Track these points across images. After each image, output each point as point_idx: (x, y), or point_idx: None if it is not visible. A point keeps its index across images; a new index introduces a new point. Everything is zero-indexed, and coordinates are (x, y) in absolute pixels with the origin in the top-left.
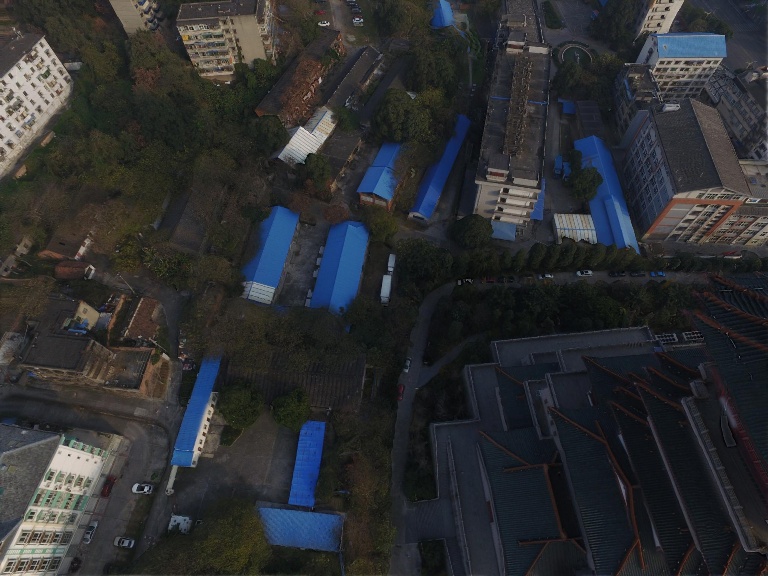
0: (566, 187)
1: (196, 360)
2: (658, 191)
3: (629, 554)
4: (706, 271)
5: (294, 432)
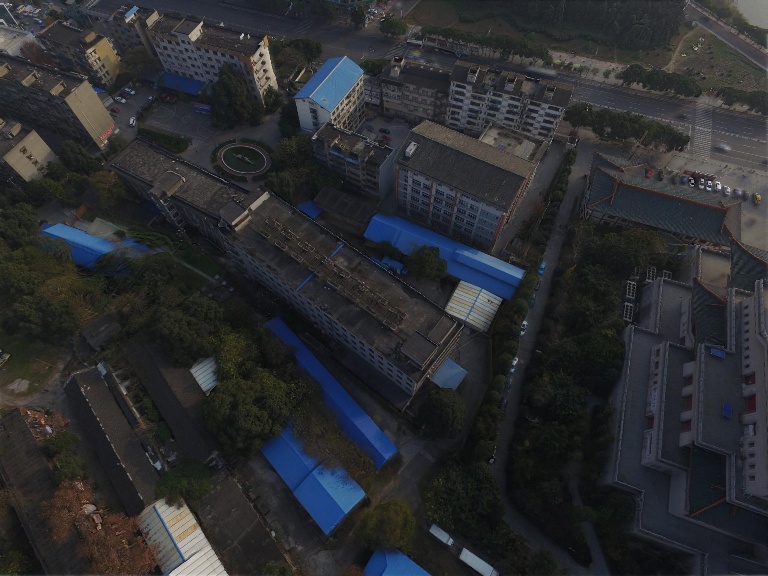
0: (409, 277)
1: None
2: (477, 216)
3: None
4: None
5: None
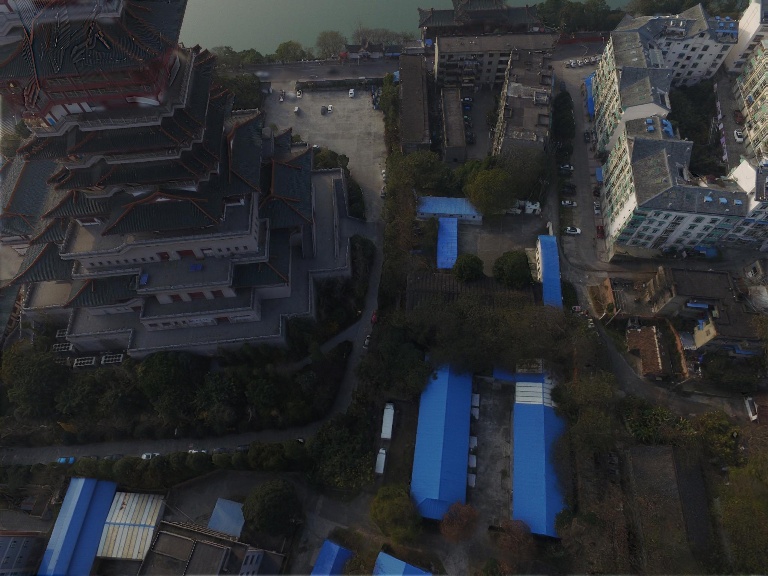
0: None
1: None
2: None
3: None
4: None
5: None
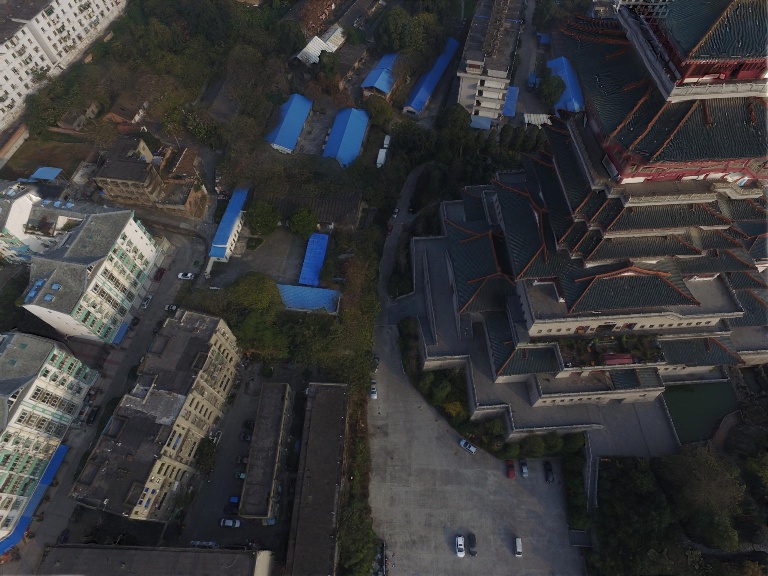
0: (537, 97)
1: (228, 192)
2: None
3: (537, 254)
4: None
5: (304, 240)
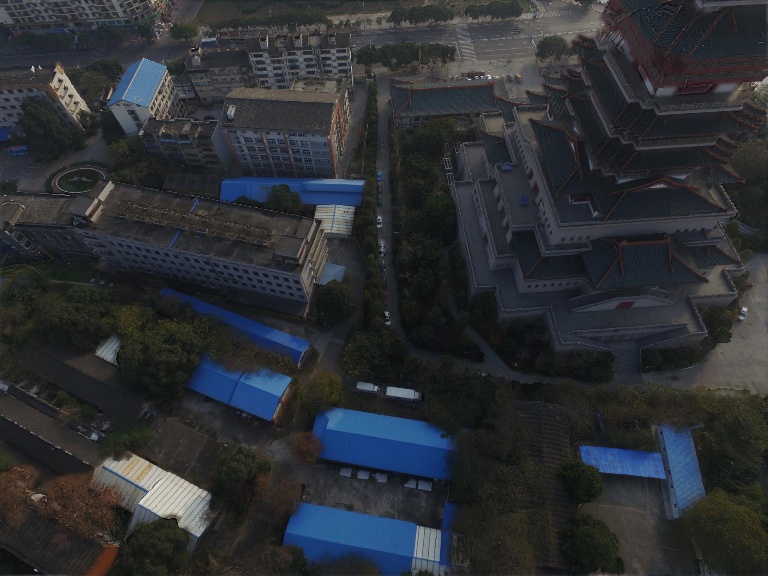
0: None
1: None
2: (310, 150)
3: None
4: None
5: None
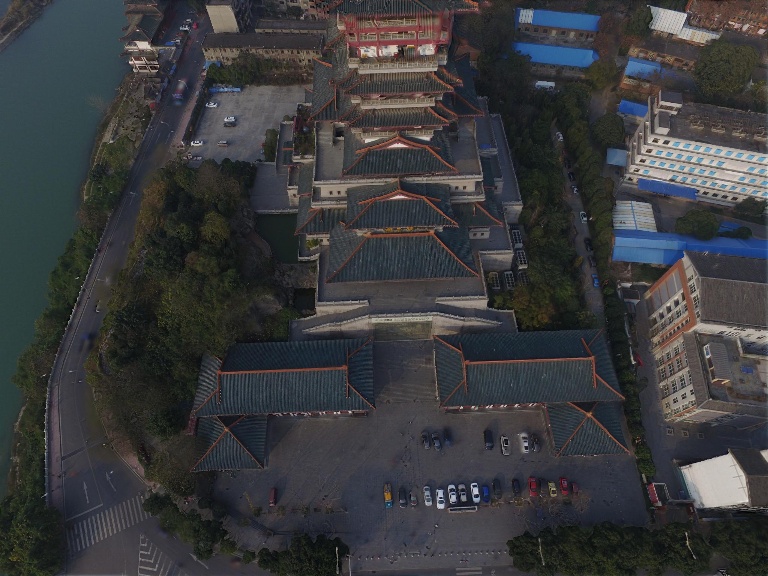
0: None
1: None
2: None
3: None
4: (608, 325)
5: None
